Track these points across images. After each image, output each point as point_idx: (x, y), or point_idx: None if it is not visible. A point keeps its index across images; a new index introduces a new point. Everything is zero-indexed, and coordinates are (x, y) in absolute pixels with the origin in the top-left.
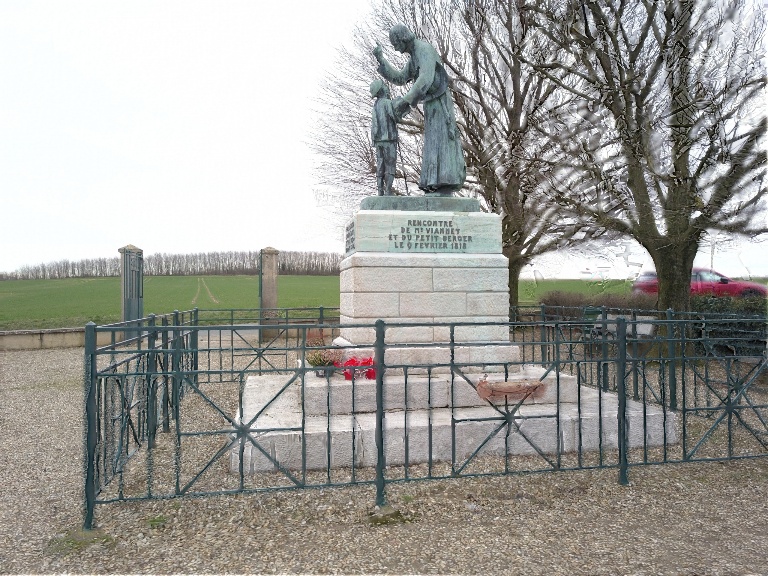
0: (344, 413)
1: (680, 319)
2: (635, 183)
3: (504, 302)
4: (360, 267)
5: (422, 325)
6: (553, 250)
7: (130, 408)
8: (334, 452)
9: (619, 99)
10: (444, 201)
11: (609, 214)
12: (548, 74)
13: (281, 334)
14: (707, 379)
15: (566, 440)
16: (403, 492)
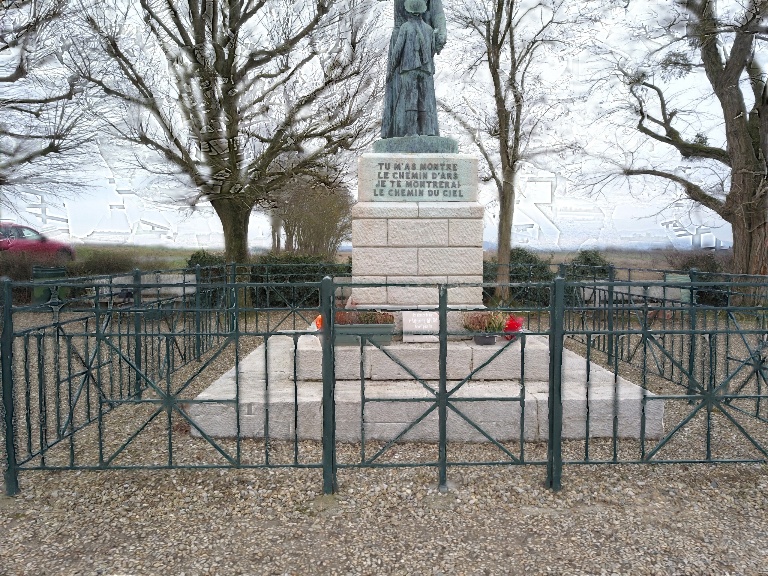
0: None
1: None
2: None
3: None
4: None
5: None
6: None
7: None
8: None
9: None
10: None
11: (243, 172)
12: None
13: (107, 324)
14: None
15: None
16: None
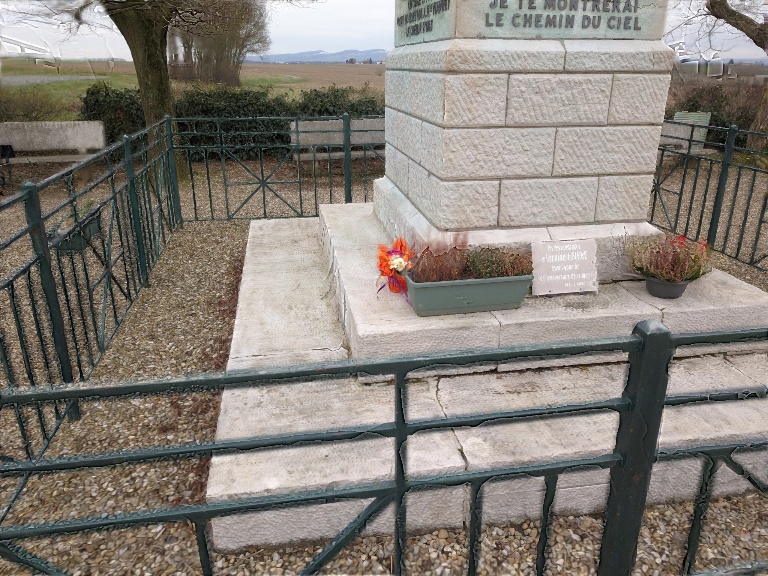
0: None
1: None
2: None
3: None
4: None
5: None
6: None
7: None
8: None
9: None
10: None
11: None
12: None
13: None
14: None
15: None
16: None
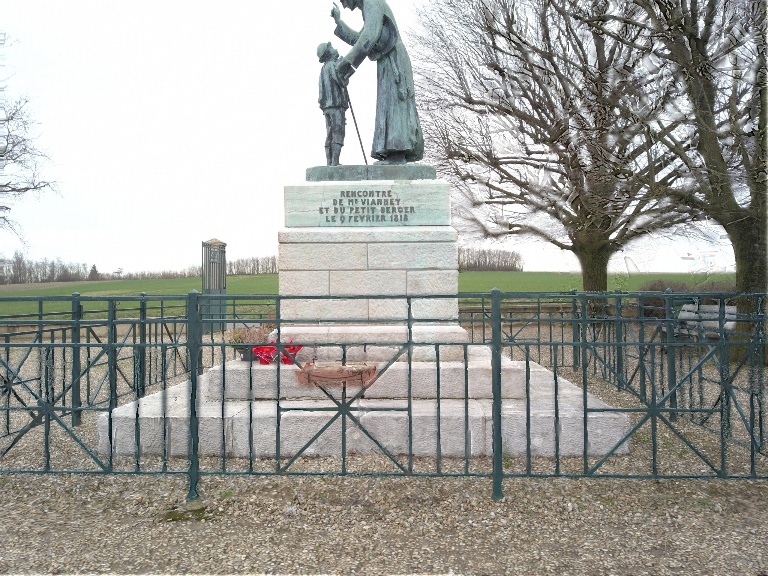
0: (248, 399)
1: (763, 308)
2: (706, 146)
3: (452, 281)
4: (286, 243)
5: (241, 298)
6: (645, 233)
7: (13, 383)
8: (201, 439)
9: (685, 48)
10: (387, 169)
11: (661, 184)
12: (604, 29)
13: None
14: (700, 376)
15: (474, 442)
16: (235, 487)
